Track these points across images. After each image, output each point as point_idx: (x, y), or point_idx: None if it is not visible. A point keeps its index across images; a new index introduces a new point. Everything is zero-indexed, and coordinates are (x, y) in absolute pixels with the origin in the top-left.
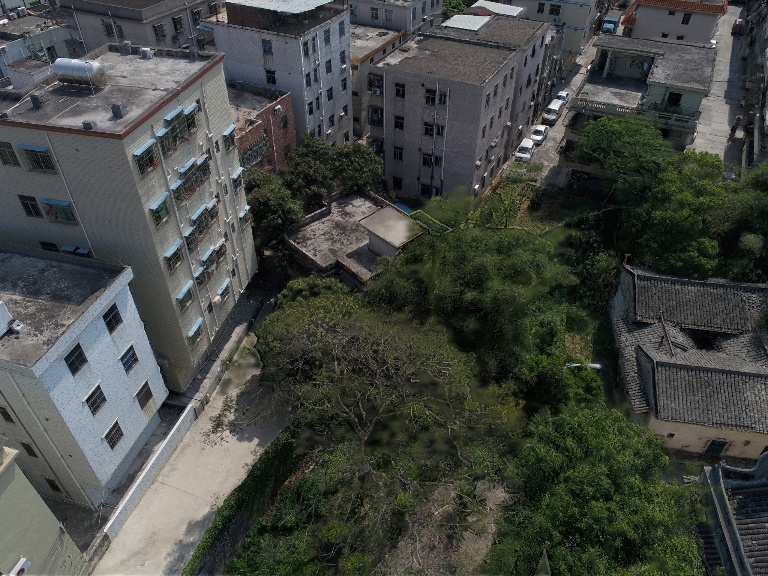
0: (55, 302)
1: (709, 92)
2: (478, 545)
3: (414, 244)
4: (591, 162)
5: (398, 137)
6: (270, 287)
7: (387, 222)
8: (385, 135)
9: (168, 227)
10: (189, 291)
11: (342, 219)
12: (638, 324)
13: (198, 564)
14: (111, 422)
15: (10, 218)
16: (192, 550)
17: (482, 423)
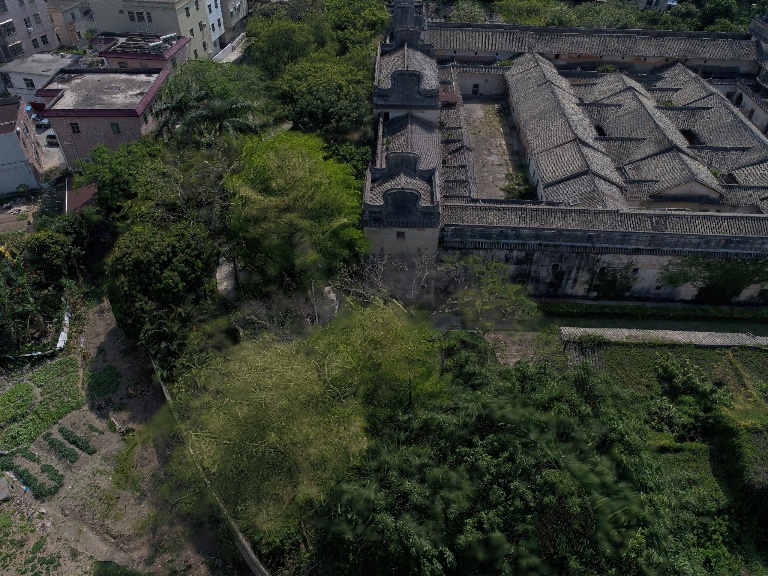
0: None
1: None
2: None
3: None
4: None
5: None
6: None
7: None
8: None
9: None
10: None
11: None
12: None
13: (245, 54)
14: None
15: None
16: None
17: None
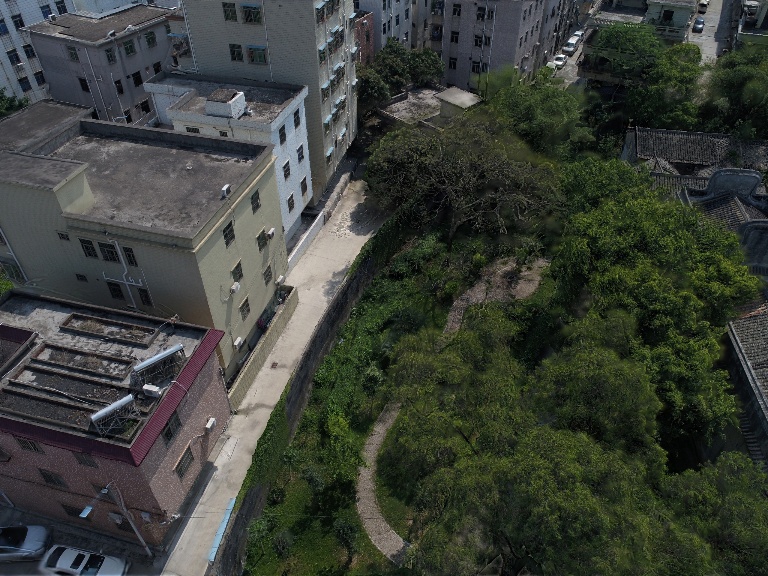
0: (265, 103)
1: None
2: (529, 286)
3: (476, 107)
4: (603, 71)
5: (453, 49)
6: (360, 156)
7: (454, 95)
8: (443, 48)
9: (324, 69)
10: (328, 123)
11: (417, 101)
12: (638, 161)
13: (354, 272)
14: (290, 193)
15: (219, 64)
16: (339, 284)
17: (539, 166)
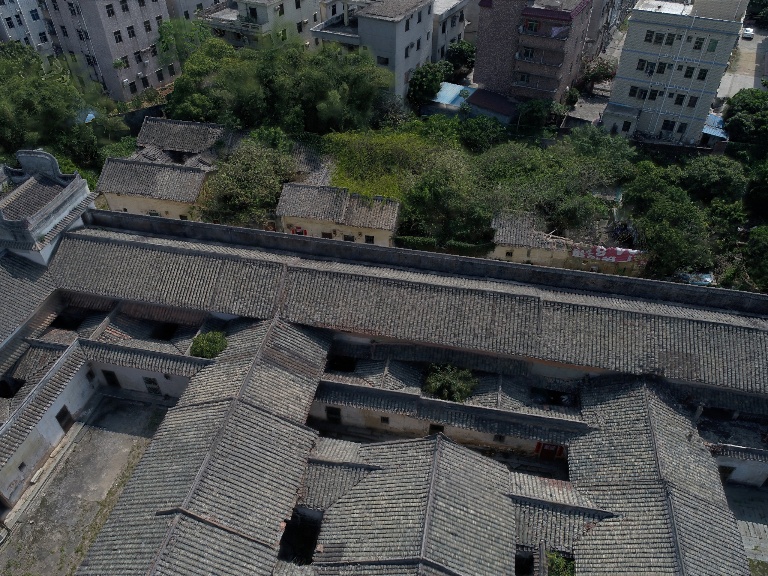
0: None
1: (267, 5)
2: None
3: None
4: None
5: (68, 43)
6: None
7: None
8: (61, 42)
9: None
10: None
11: None
12: None
13: None
14: None
15: None
16: None
17: None
